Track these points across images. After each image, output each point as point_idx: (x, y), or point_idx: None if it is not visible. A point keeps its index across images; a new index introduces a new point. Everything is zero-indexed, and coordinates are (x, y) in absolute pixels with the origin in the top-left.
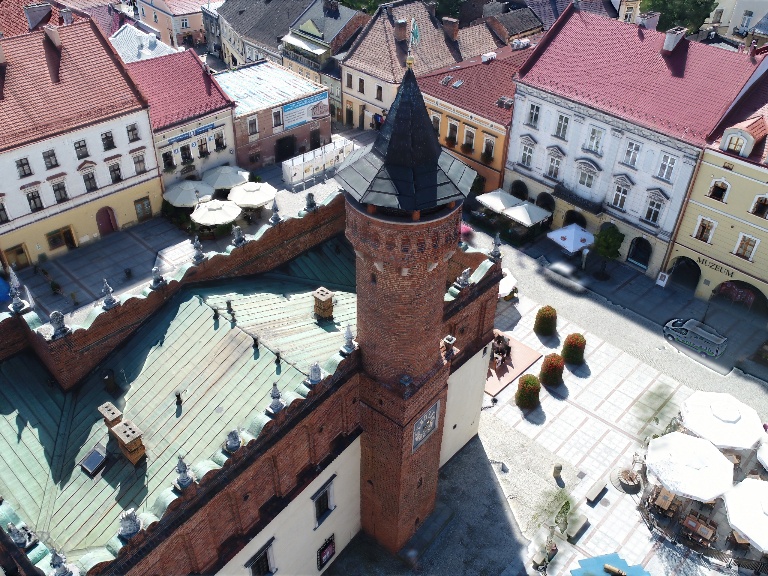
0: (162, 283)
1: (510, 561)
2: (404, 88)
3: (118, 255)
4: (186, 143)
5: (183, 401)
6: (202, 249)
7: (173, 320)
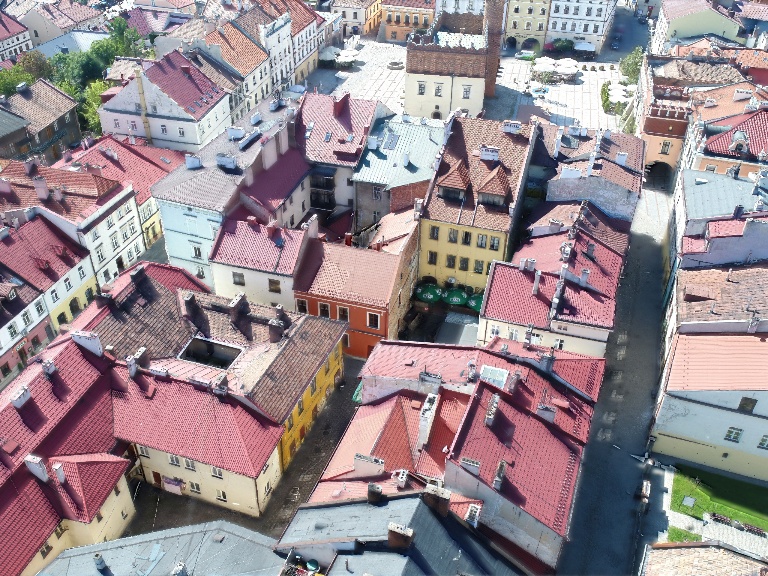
0: None
1: None
2: None
3: (322, 78)
4: None
5: None
6: (349, 72)
7: None
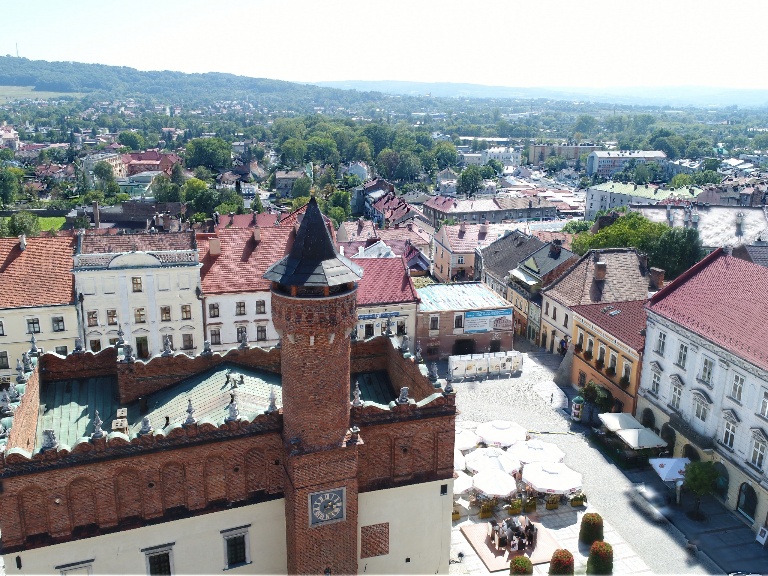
0: (209, 353)
1: None
2: (308, 208)
3: None
4: (371, 322)
5: (170, 424)
6: None
7: (205, 380)
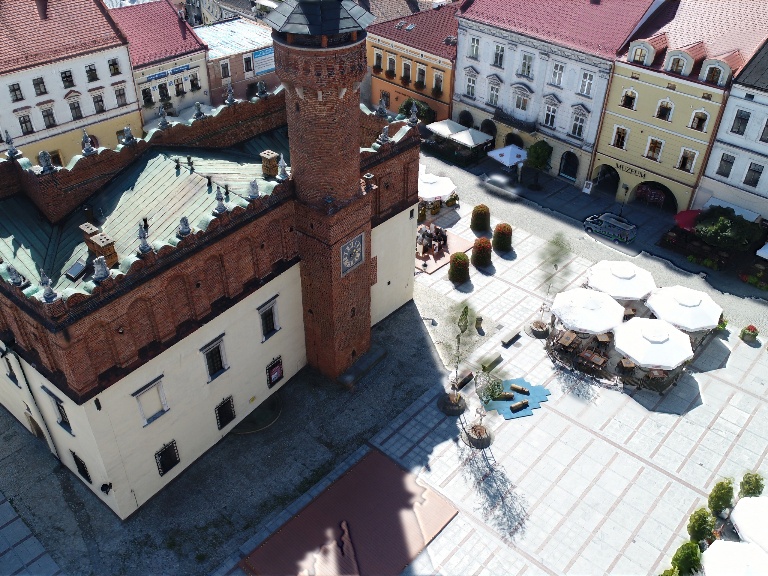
0: (133, 141)
1: (433, 385)
2: None
3: None
4: (163, 81)
5: (149, 225)
6: None
7: (142, 172)
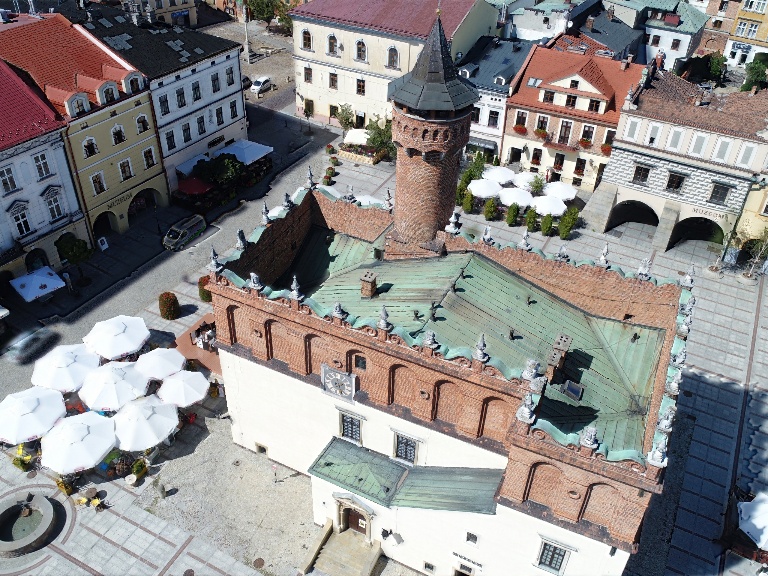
0: None
1: None
2: None
3: None
4: None
5: None
6: None
7: None
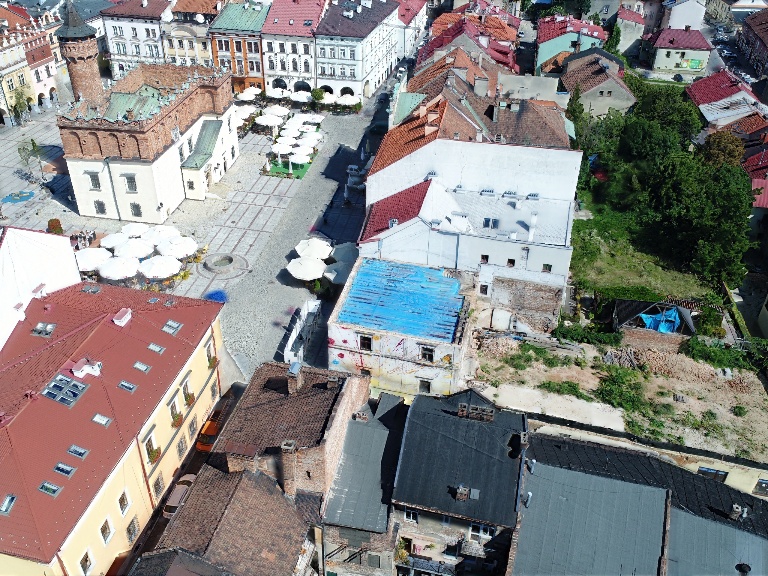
0: None
1: None
2: None
3: (352, 231)
4: None
5: None
6: None
7: None
